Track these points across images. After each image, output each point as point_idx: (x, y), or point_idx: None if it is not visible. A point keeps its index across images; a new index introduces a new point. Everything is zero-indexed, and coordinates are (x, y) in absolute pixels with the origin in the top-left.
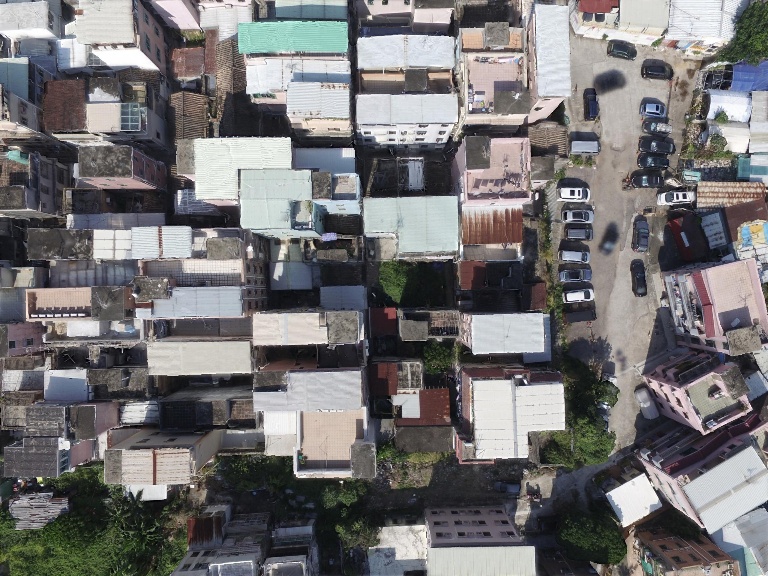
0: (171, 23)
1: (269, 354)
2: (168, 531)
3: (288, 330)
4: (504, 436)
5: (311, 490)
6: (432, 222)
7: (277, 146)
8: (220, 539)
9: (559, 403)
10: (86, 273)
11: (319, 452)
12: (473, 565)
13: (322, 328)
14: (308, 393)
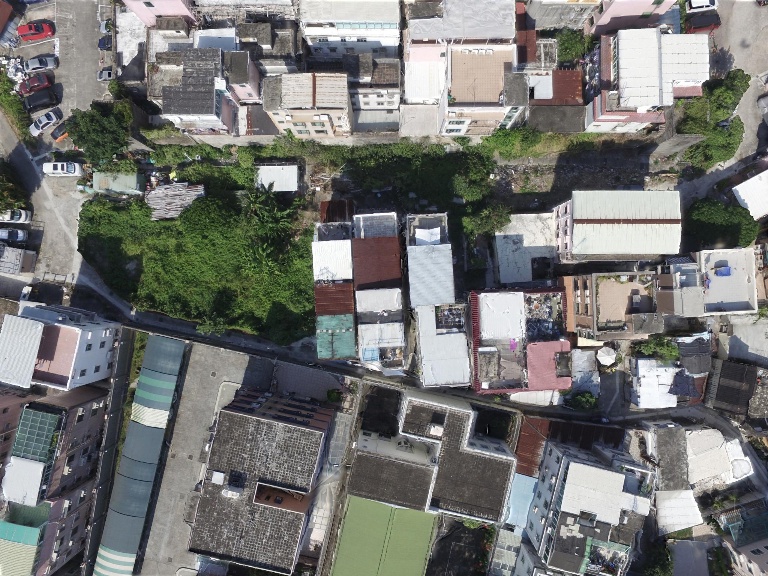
0: None
1: None
2: (295, 231)
3: None
4: (649, 84)
5: (436, 189)
6: None
7: None
8: None
9: (704, 53)
10: None
11: (467, 94)
12: (618, 206)
13: None
14: (464, 19)
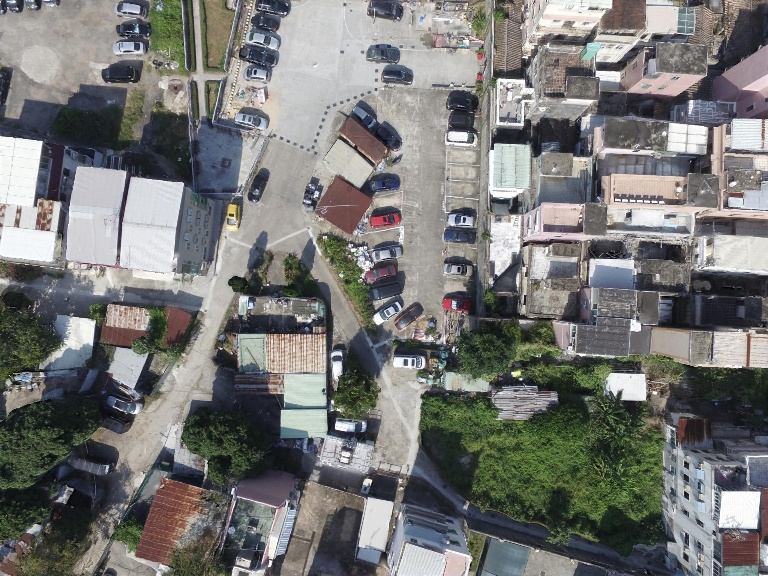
0: None
1: None
2: None
3: None
4: None
5: None
6: None
7: None
8: (711, 440)
9: None
10: (635, 168)
11: None
12: None
13: None
14: None
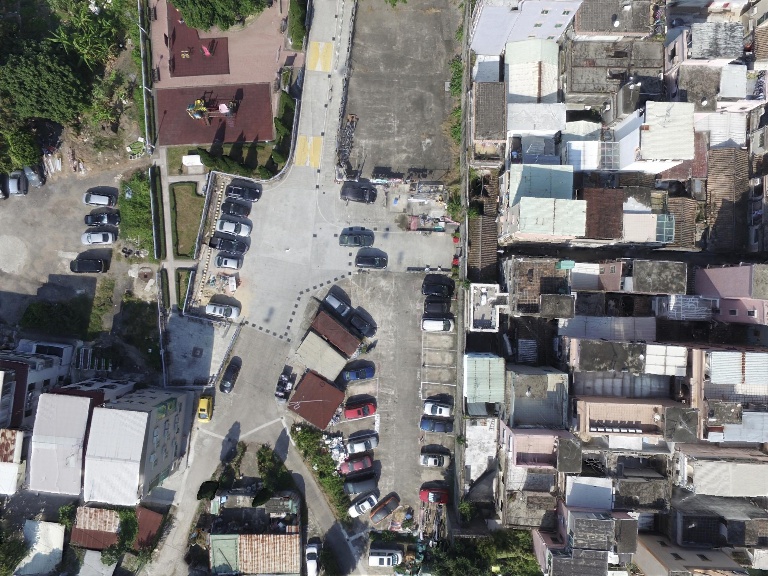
0: None
1: None
2: None
3: None
4: None
5: None
6: None
7: None
8: None
9: None
10: (613, 382)
11: None
12: None
13: None
14: None
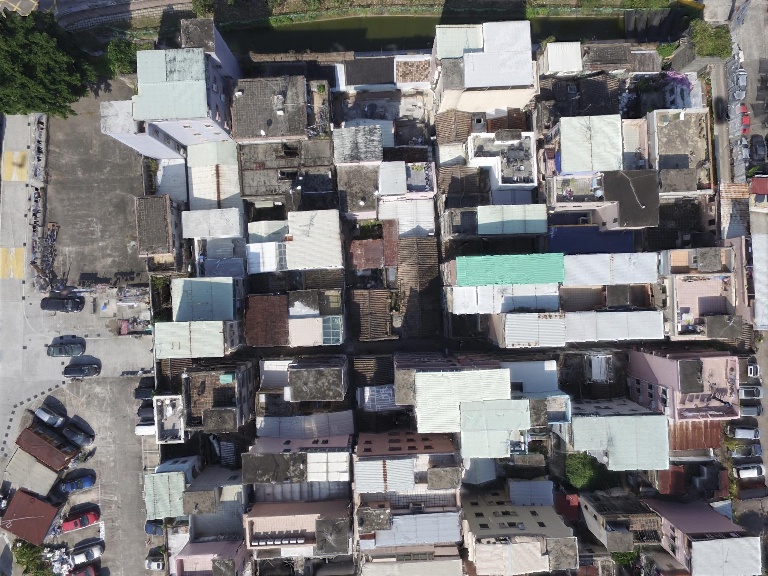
0: (351, 217)
1: (460, 550)
2: None
3: (512, 561)
4: None
5: None
6: (642, 441)
7: (496, 377)
8: None
9: None
10: (291, 486)
11: None
12: None
13: (543, 556)
14: None
